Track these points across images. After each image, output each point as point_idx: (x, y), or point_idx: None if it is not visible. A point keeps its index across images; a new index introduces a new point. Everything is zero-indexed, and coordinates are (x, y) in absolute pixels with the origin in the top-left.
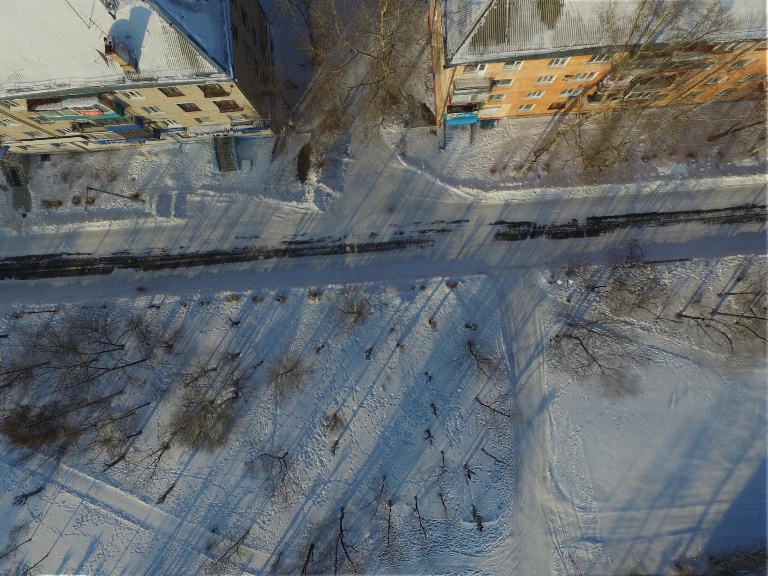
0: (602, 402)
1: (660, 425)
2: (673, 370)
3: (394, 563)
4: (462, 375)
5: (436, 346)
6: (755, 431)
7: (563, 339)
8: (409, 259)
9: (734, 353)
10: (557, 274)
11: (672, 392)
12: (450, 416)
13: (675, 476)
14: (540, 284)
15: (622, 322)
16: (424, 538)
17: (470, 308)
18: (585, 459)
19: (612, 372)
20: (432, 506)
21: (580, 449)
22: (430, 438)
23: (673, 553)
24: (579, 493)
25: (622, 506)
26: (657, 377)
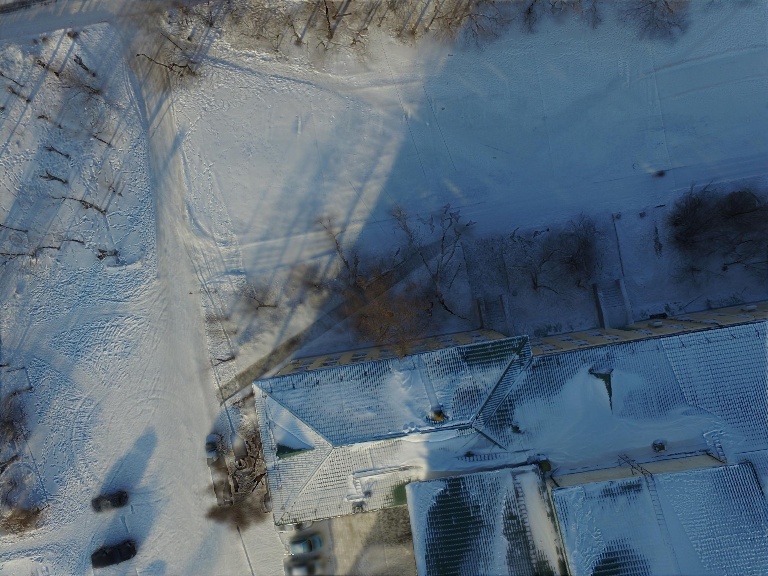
0: (231, 135)
1: (288, 151)
2: (296, 96)
3: (46, 317)
4: (94, 124)
5: (66, 98)
6: (381, 147)
7: (186, 76)
8: (34, 17)
9: (354, 73)
10: (175, 14)
11: (297, 117)
12: (85, 165)
13: (309, 200)
14: (162, 27)
15: (244, 55)
16: (72, 289)
17: (96, 57)
18: (220, 193)
19: (238, 105)
20: (76, 255)
21: (214, 184)
22: (47, 175)
23: (315, 276)
24: (218, 227)
25: (261, 236)
26: (282, 104)
